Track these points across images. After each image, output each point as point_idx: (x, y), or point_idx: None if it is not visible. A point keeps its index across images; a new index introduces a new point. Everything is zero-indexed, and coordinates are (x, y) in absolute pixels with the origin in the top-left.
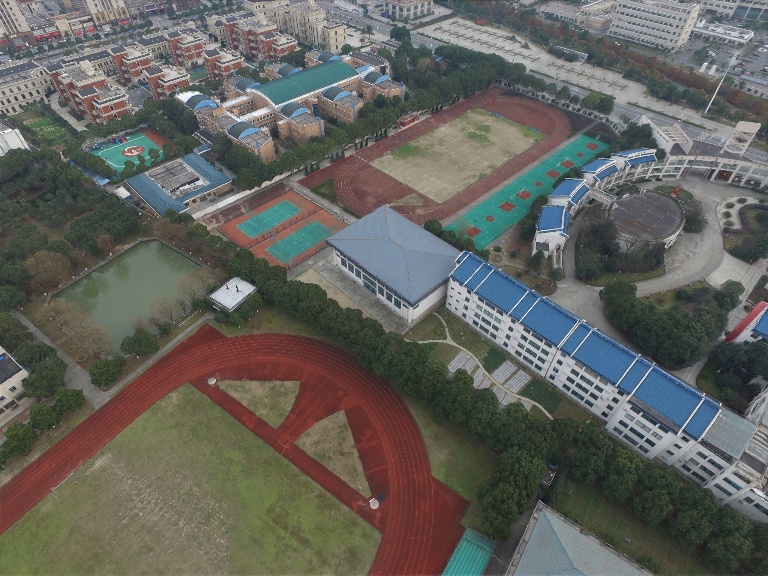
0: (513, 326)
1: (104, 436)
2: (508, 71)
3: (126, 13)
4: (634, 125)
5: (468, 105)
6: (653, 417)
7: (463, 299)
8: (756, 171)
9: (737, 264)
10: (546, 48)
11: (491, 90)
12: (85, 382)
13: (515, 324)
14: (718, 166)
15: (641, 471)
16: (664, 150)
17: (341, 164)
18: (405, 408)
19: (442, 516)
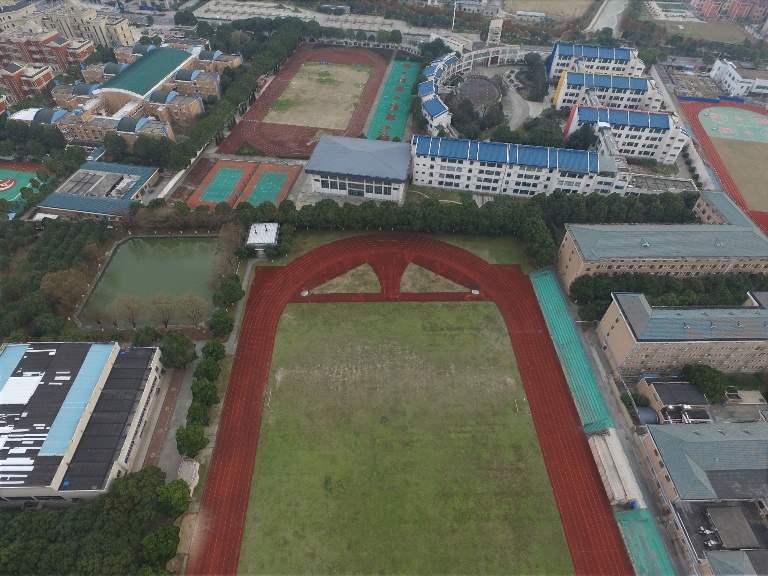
0: (472, 167)
1: (262, 363)
2: (309, 28)
3: None
4: None
5: (296, 62)
6: (574, 172)
7: (429, 168)
8: (510, 52)
9: (536, 104)
10: (313, 9)
11: (302, 47)
12: (200, 347)
13: (473, 164)
14: (490, 54)
15: (585, 199)
16: (458, 52)
17: (239, 129)
18: (444, 243)
19: (513, 277)
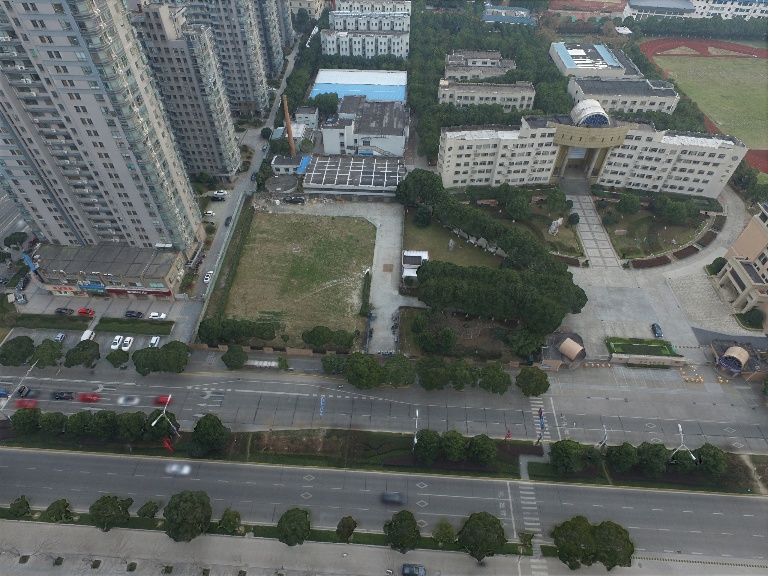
0: (732, 6)
1: None
2: None
3: None
4: None
5: None
6: None
7: (702, 8)
8: None
9: None
10: None
11: None
12: None
13: (733, 4)
14: None
15: None
16: None
17: (553, 1)
18: (723, 41)
19: None
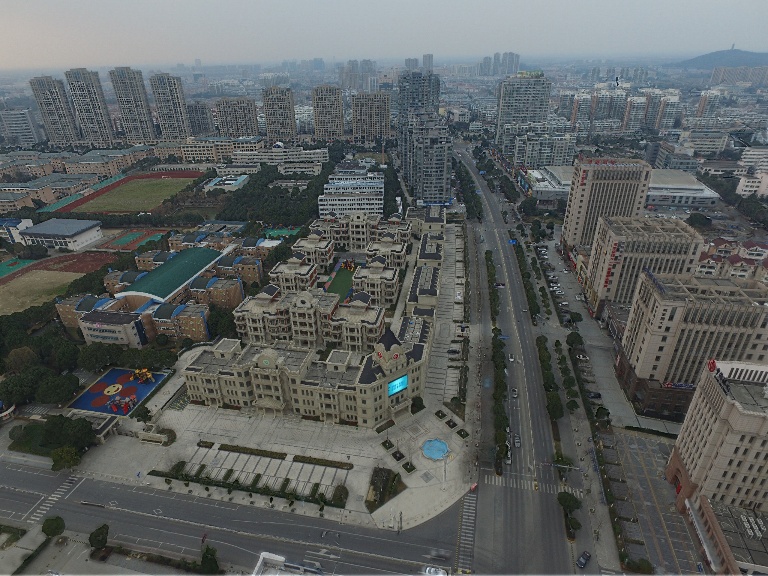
0: None
1: None
2: None
3: None
4: None
5: None
6: None
7: None
8: None
9: None
10: None
11: None
12: None
13: None
14: None
15: None
16: None
17: None
18: None
19: None
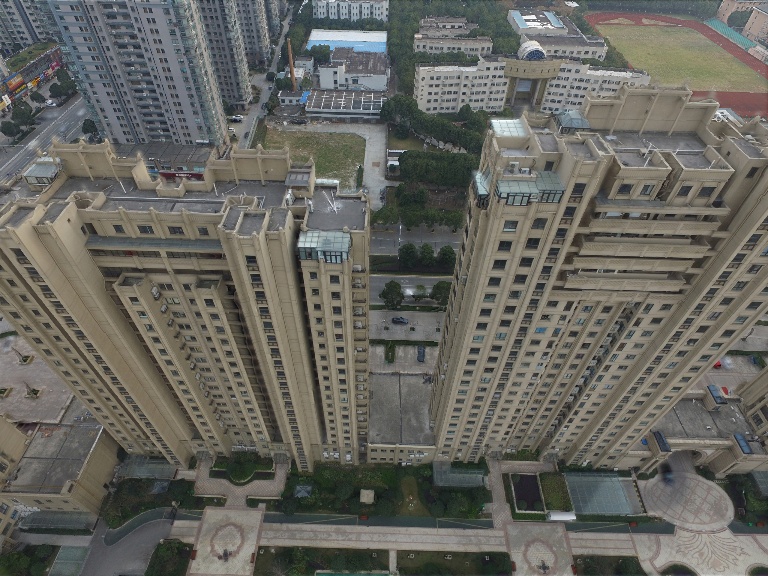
0: None
1: None
2: None
3: None
4: None
5: None
6: None
7: None
8: None
9: None
10: None
11: None
12: None
13: None
14: None
15: None
16: None
17: None
18: None
19: None
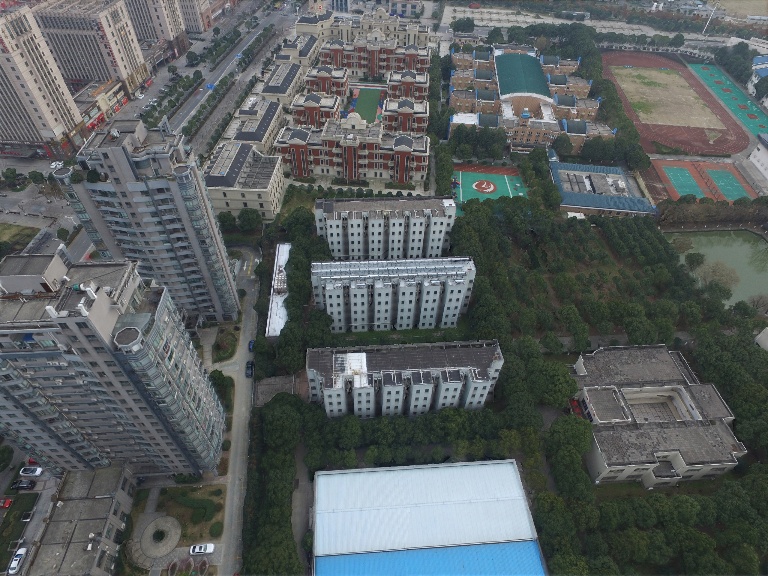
0: None
1: None
2: (594, 34)
3: (147, 70)
4: (725, 46)
5: None
6: None
7: None
8: None
9: None
10: (551, 15)
11: None
12: None
13: None
14: None
15: None
16: (767, 54)
17: None
18: None
19: None
